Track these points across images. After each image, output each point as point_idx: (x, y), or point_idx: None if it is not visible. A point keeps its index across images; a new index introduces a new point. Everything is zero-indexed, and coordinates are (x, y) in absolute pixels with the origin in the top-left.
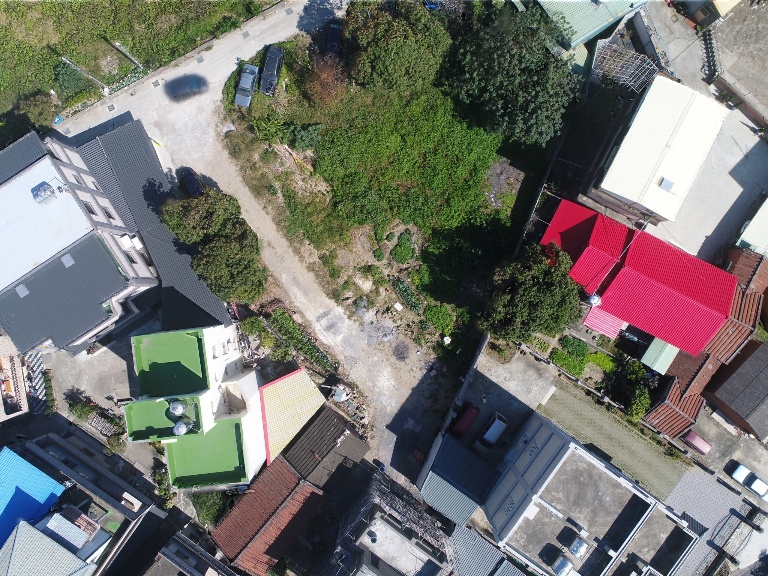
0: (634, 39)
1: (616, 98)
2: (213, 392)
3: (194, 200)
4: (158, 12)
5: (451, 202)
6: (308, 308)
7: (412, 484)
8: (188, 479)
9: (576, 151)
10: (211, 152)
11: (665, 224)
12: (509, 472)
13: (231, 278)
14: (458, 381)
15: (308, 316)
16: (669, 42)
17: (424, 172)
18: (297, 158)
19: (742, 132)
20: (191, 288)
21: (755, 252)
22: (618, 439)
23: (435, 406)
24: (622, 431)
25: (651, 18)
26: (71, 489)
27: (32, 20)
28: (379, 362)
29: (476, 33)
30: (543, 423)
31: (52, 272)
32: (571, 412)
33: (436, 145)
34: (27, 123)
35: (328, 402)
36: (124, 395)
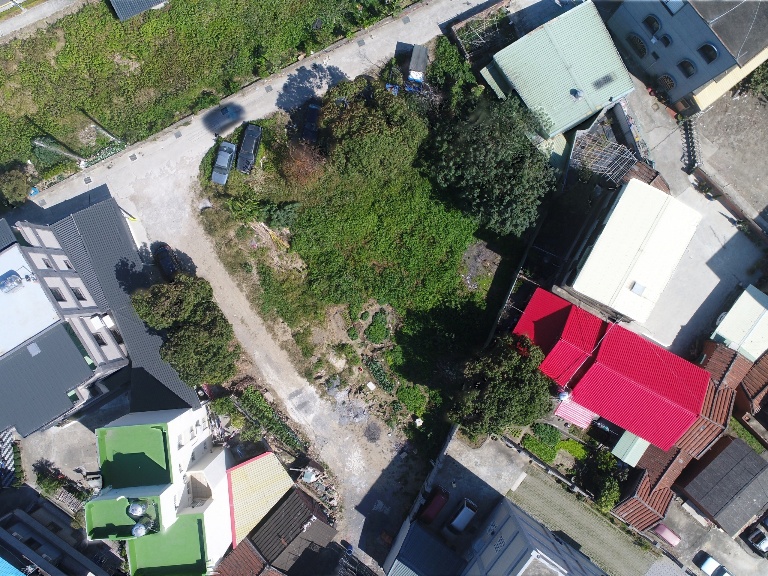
0: (614, 126)
1: (594, 186)
2: (176, 485)
3: (164, 286)
4: (137, 86)
5: (426, 284)
6: (280, 386)
7: (379, 566)
8: (149, 571)
9: (553, 237)
10: (187, 228)
11: (638, 322)
12: (475, 564)
13: (200, 365)
14: (428, 465)
15: (280, 394)
16: (649, 130)
17: (400, 253)
18: (273, 235)
19: (720, 223)
20: (161, 370)
21: (729, 348)
22: (588, 527)
23: (405, 488)
24: (592, 519)
25: (632, 107)
26: (32, 575)
27: (10, 90)
28: (350, 442)
29: (454, 120)
30: (510, 516)
31: (18, 360)
32: (541, 499)
33: (413, 226)
34: (1, 198)
35: (297, 484)
36: (93, 468)
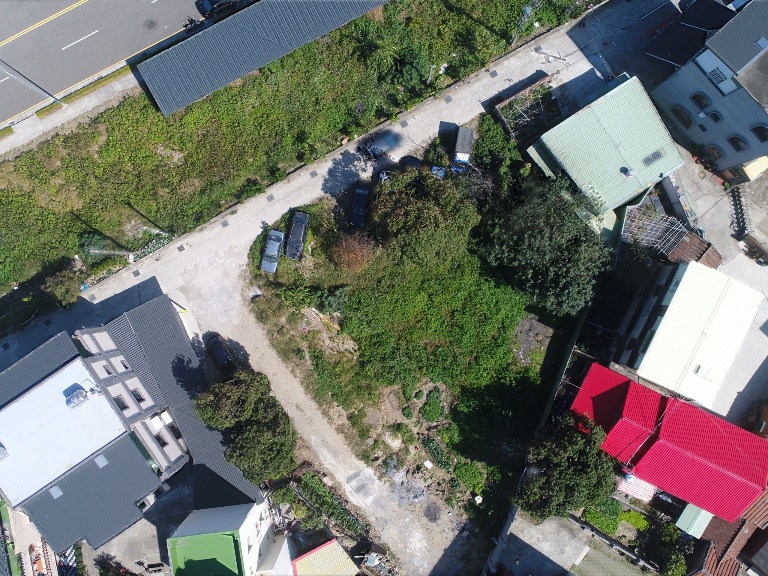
0: (662, 196)
1: (645, 258)
2: None
3: (225, 386)
4: (182, 176)
5: (480, 361)
6: (338, 469)
7: None
8: None
9: (605, 309)
10: (238, 316)
11: None
12: None
13: (264, 464)
14: (491, 542)
15: (338, 478)
16: (697, 198)
17: (452, 331)
18: (324, 318)
19: None
20: (222, 465)
21: None
22: None
23: (468, 567)
24: None
25: (679, 177)
26: None
27: (55, 186)
28: (410, 523)
29: (504, 201)
30: None
31: (86, 473)
32: (605, 572)
33: (463, 303)
34: (54, 300)
35: (361, 570)
36: (154, 560)
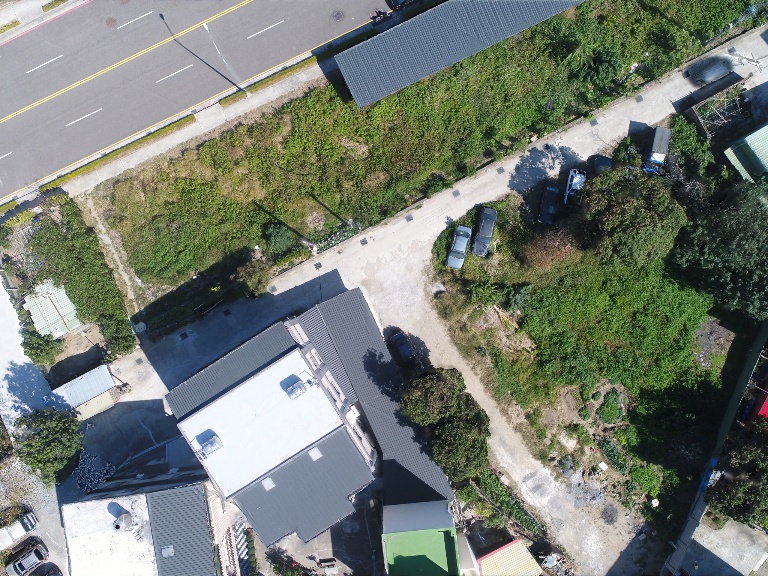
0: None
1: None
2: None
3: (429, 381)
4: (367, 169)
5: (661, 363)
6: (514, 469)
7: None
8: None
9: None
10: (419, 312)
11: None
12: None
13: (466, 461)
14: (669, 546)
15: (514, 477)
16: None
17: (633, 332)
18: (503, 316)
19: None
20: (413, 461)
21: None
22: None
23: (644, 570)
24: None
25: None
26: None
27: (238, 176)
28: (587, 525)
29: None
30: None
31: (299, 465)
32: None
33: (645, 304)
34: (245, 290)
35: None
36: (326, 555)
